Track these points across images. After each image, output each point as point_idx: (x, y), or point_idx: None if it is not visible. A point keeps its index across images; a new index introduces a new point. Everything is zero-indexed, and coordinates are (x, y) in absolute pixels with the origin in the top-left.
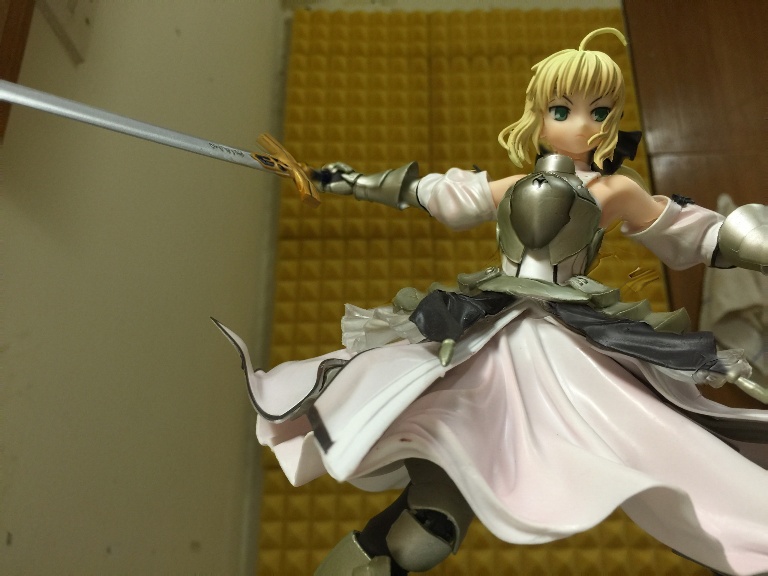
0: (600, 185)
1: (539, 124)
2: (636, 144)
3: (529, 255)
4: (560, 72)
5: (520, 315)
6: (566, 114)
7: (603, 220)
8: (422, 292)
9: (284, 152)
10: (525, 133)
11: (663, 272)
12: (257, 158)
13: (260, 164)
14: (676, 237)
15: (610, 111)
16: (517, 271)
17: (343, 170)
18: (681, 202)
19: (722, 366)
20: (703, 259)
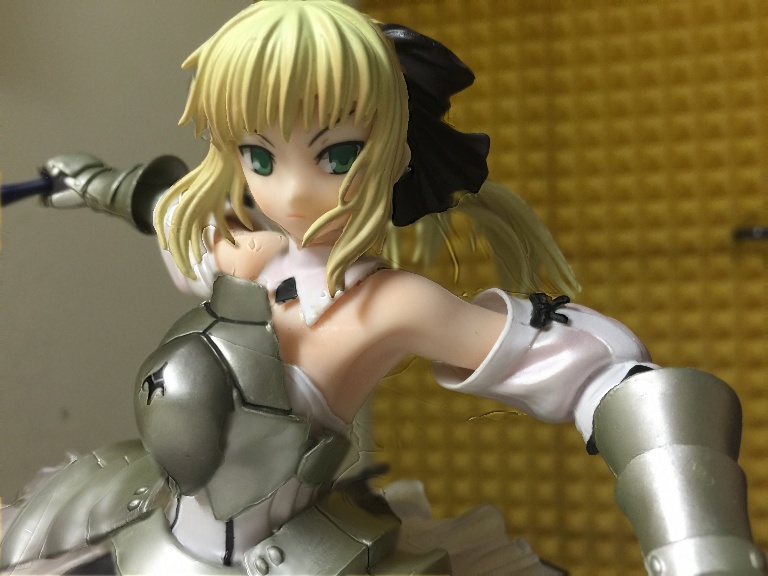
0: (349, 313)
1: (236, 173)
2: (481, 158)
3: None
4: (227, 79)
5: None
6: (269, 162)
7: (357, 384)
8: (45, 522)
9: None
10: (208, 197)
11: None
12: None
13: None
14: (519, 398)
15: (360, 149)
16: (175, 512)
17: (64, 172)
18: (536, 322)
19: None
20: (579, 434)
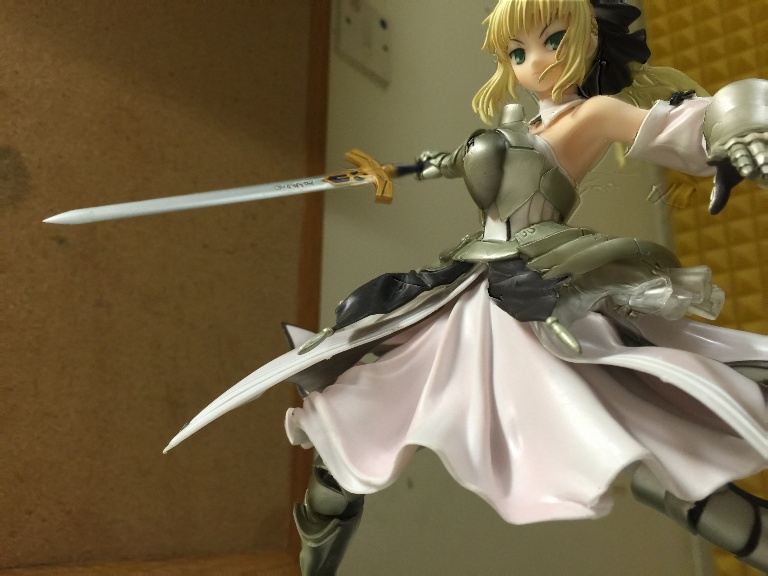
0: (567, 117)
1: (510, 73)
2: (643, 43)
3: (489, 216)
4: (501, 18)
5: (477, 278)
6: (523, 55)
7: (574, 154)
8: None
9: (368, 162)
10: (497, 88)
11: (693, 181)
12: (329, 180)
13: (331, 185)
14: (668, 145)
15: None
16: None
17: (430, 157)
18: (672, 101)
19: (635, 300)
20: (709, 160)
